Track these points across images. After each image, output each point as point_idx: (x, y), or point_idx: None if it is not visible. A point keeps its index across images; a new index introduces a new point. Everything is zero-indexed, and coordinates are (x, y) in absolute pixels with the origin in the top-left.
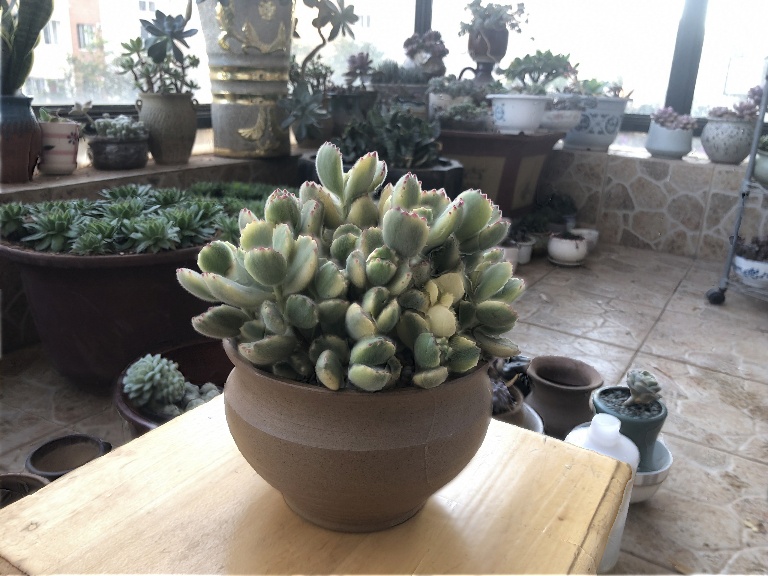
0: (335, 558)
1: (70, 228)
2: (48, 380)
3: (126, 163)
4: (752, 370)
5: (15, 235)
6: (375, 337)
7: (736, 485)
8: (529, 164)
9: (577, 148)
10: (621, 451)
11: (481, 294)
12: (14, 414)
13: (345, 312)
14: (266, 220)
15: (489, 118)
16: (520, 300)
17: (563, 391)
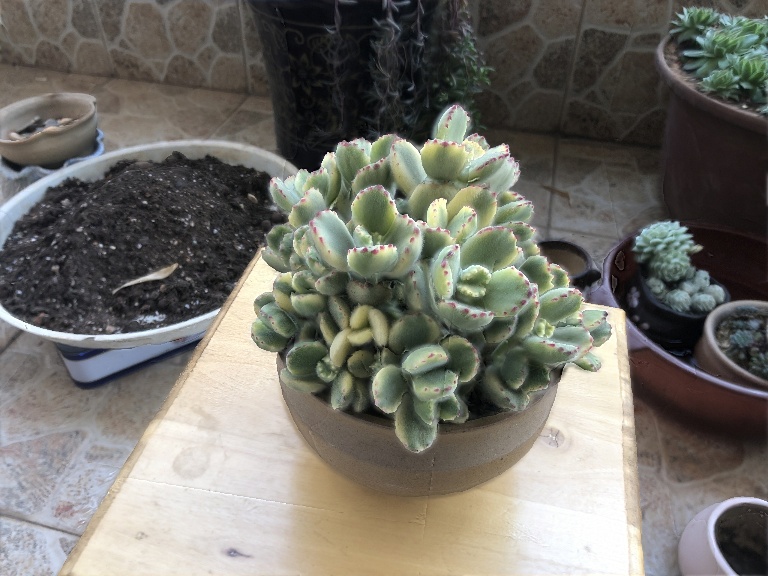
0: (307, 445)
1: (727, 57)
2: (661, 193)
3: None
4: None
5: (686, 45)
6: (281, 310)
7: None
8: None
9: None
10: None
11: None
12: (604, 205)
13: None
14: None
15: None
16: None
17: None
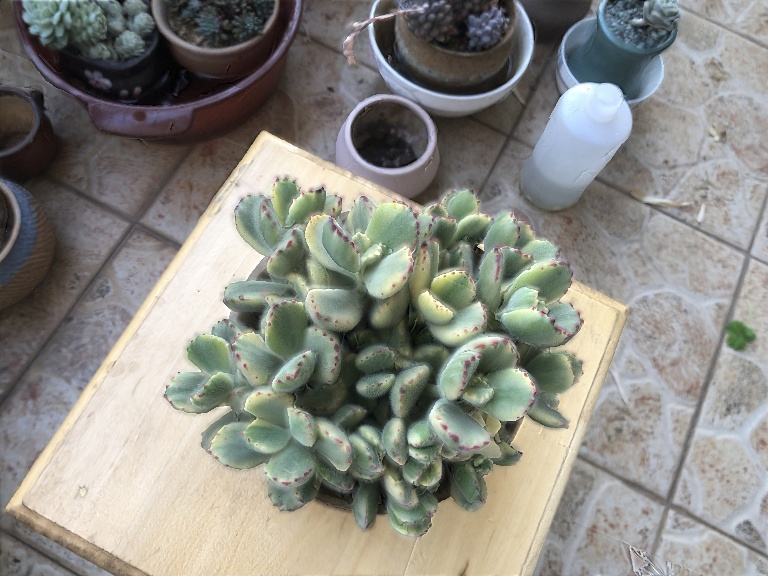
0: None
1: None
2: None
3: None
4: None
5: None
6: None
7: (717, 78)
8: None
9: None
10: (615, 126)
11: None
12: None
13: (384, 476)
14: (275, 392)
15: None
16: None
17: None
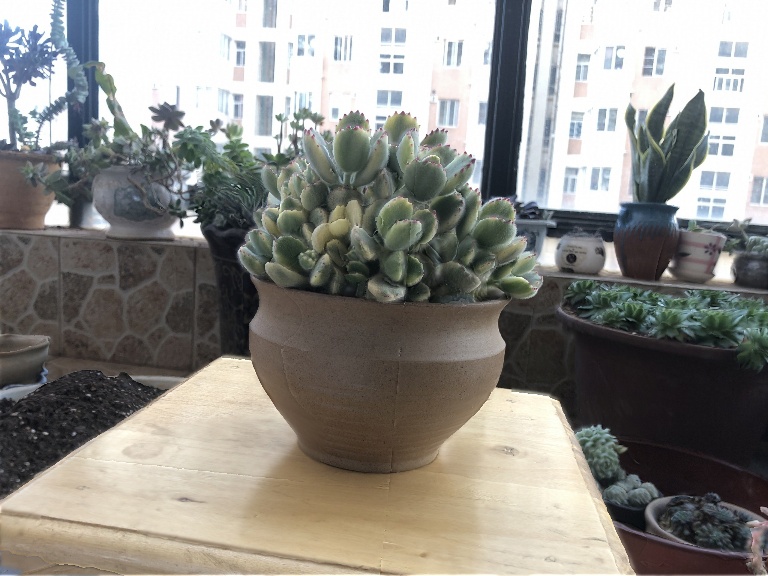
0: (264, 446)
1: (612, 305)
2: None
3: (766, 282)
4: None
5: (578, 304)
6: (267, 232)
7: None
8: None
9: None
10: None
11: None
12: None
13: None
14: None
15: None
16: None
17: None
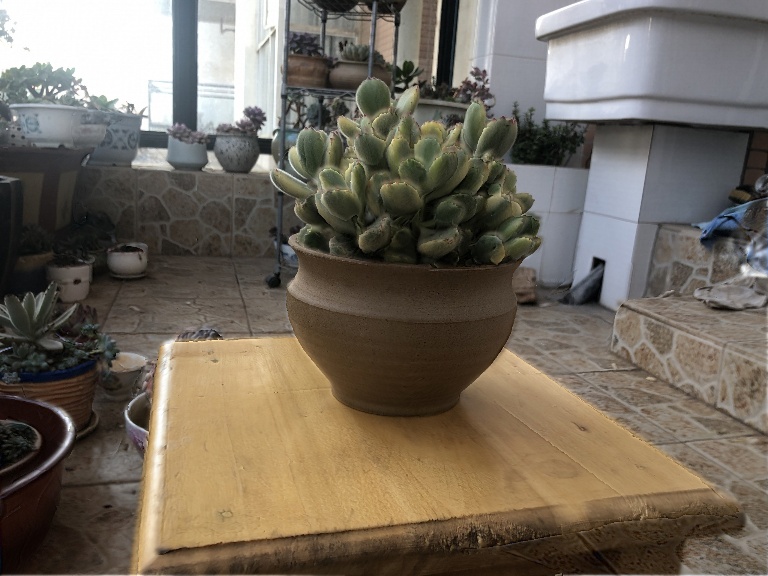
0: (463, 426)
1: None
2: None
3: None
4: None
5: None
6: None
7: None
8: (65, 180)
9: (102, 164)
10: None
11: None
12: None
13: (484, 205)
14: None
15: (6, 132)
16: (116, 315)
17: None
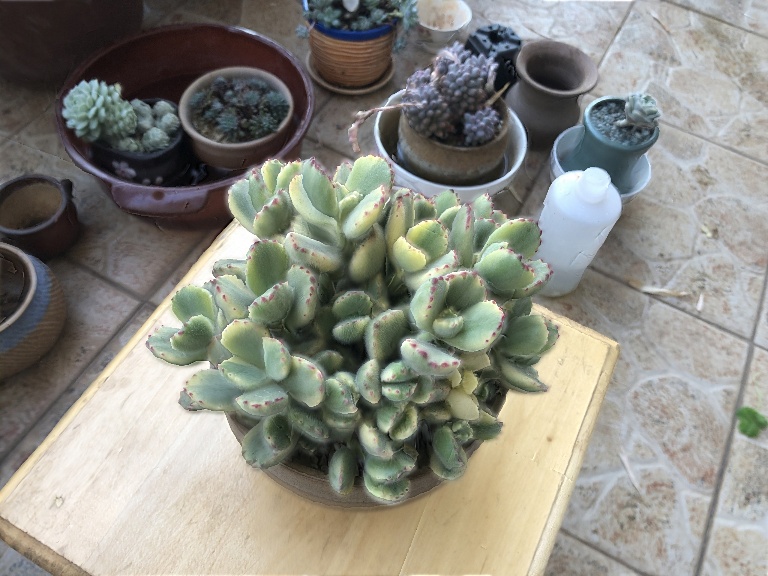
0: (347, 514)
1: None
2: None
3: None
4: (759, 17)
5: None
6: (393, 456)
7: (704, 182)
8: None
9: None
10: (605, 207)
11: (507, 350)
12: None
13: (358, 426)
14: (251, 320)
15: None
16: None
17: (553, 96)
